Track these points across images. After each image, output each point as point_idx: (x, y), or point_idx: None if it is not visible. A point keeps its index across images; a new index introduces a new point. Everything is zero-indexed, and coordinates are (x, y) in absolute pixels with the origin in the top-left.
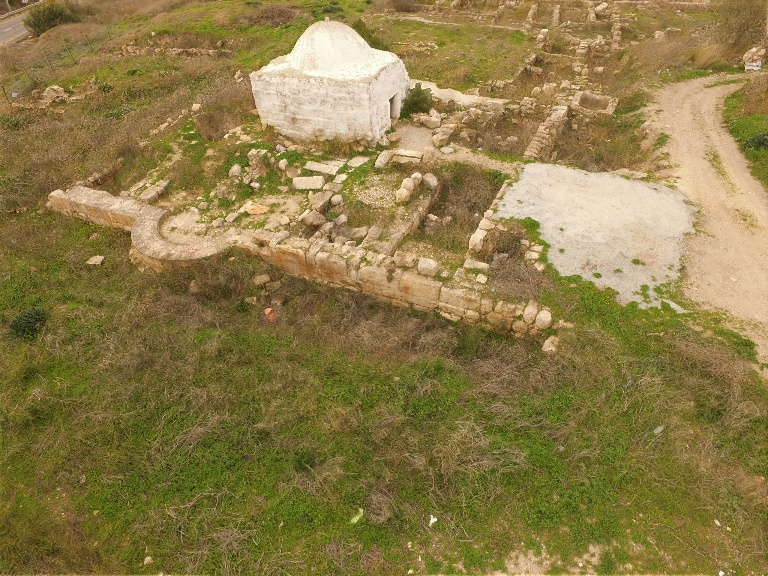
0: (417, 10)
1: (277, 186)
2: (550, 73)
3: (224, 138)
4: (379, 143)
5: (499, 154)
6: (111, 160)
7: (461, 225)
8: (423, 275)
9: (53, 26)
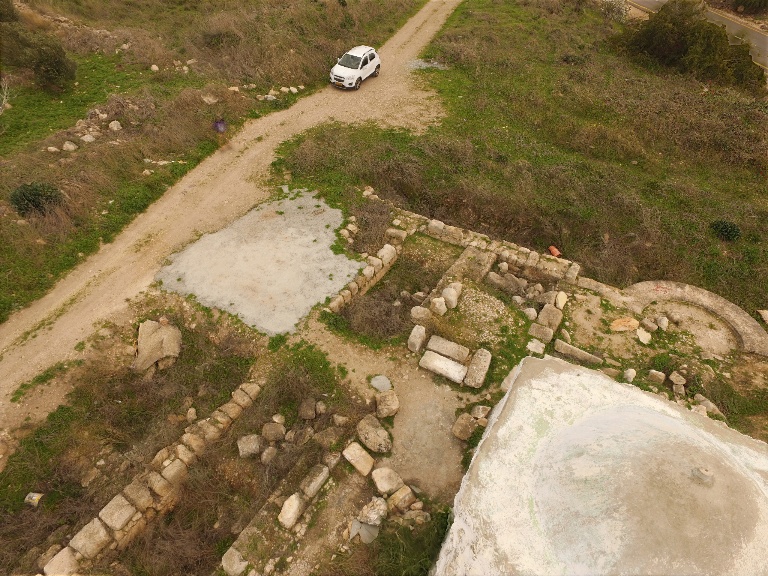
0: None
1: (623, 365)
2: None
3: None
4: None
5: None
6: None
7: None
8: None
9: None
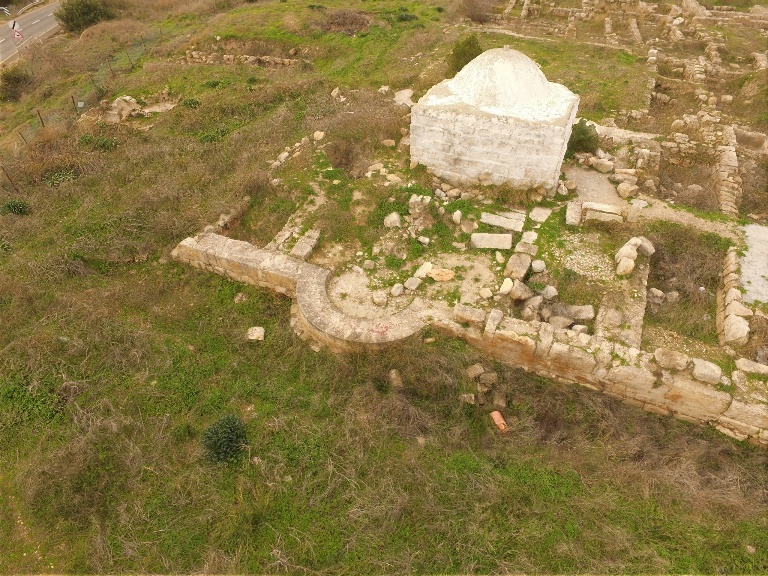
0: (488, 19)
1: (451, 242)
2: (672, 100)
3: (366, 176)
4: (558, 192)
5: (698, 209)
6: (236, 199)
7: (694, 303)
8: (700, 382)
9: (87, 21)
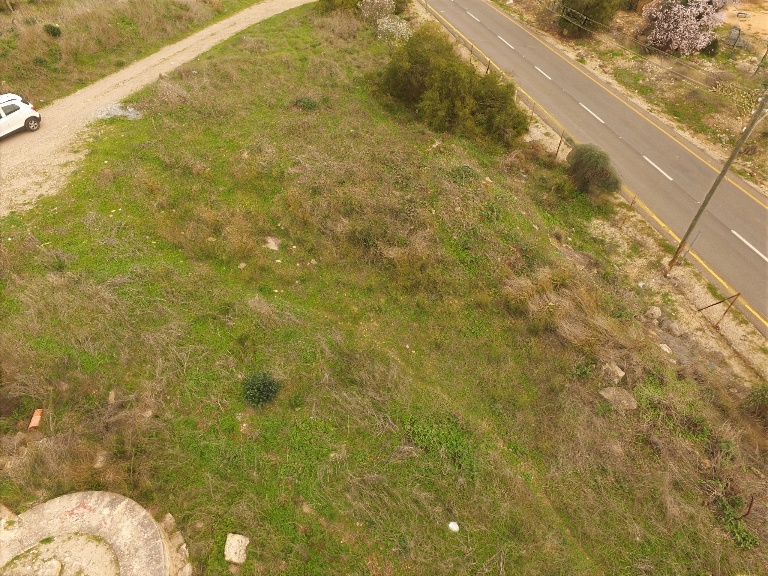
0: None
1: None
2: None
3: None
4: None
5: None
6: None
7: None
8: None
9: None
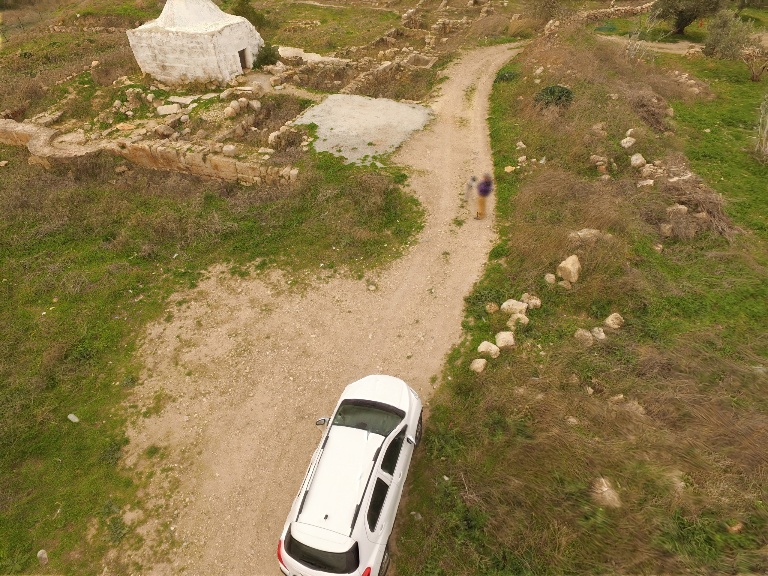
0: None
1: (146, 113)
2: (406, 43)
3: (112, 84)
4: (229, 83)
5: (318, 90)
6: (21, 101)
7: None
8: (227, 156)
9: None
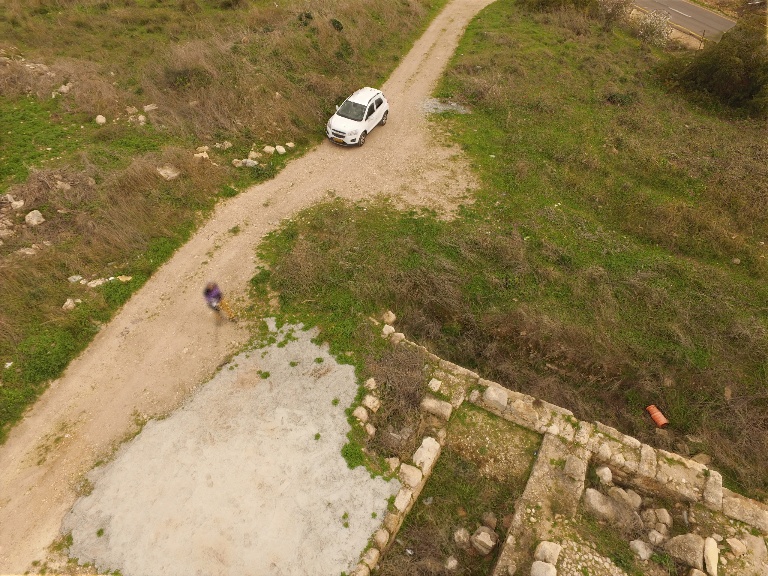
0: None
1: None
2: None
3: None
4: None
5: None
6: None
7: None
8: None
9: None
